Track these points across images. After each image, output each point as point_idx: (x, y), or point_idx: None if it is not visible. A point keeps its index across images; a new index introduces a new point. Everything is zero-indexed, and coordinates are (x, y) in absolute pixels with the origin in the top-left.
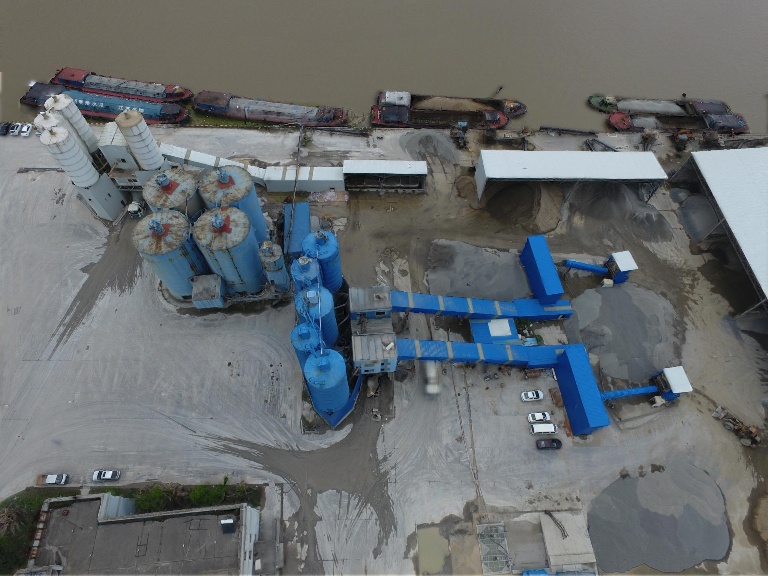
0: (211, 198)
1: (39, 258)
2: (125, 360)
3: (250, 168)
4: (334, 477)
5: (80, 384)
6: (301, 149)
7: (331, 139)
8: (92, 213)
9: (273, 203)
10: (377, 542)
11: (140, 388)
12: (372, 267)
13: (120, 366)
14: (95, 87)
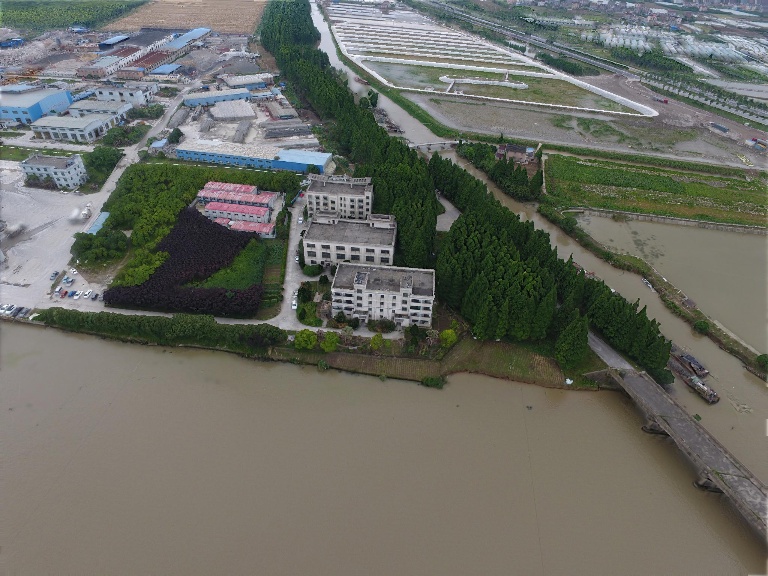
0: None
1: (46, 245)
2: None
3: None
4: (1, 185)
5: None
6: None
7: None
8: (8, 259)
9: None
10: (4, 176)
11: None
12: None
13: None
14: None
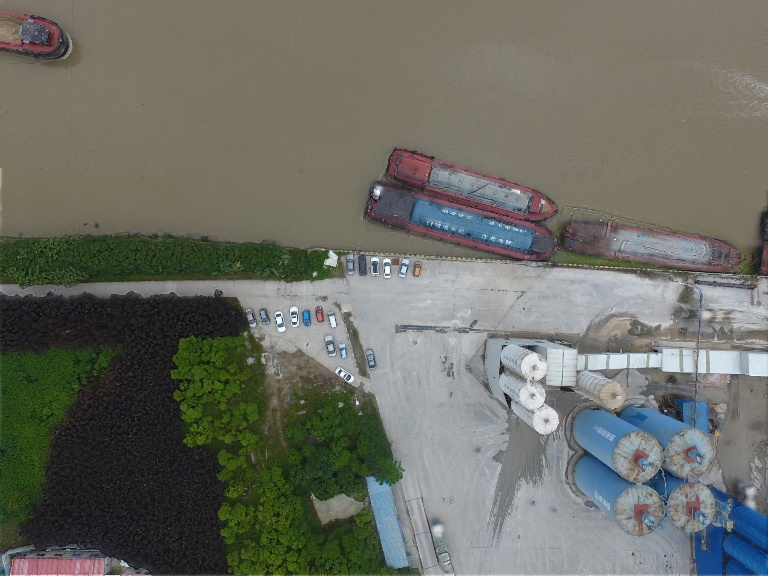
0: (678, 472)
1: (452, 444)
2: (551, 549)
3: (651, 358)
4: None
5: (521, 568)
6: (682, 306)
7: (714, 291)
8: (486, 391)
9: (657, 382)
10: None
11: (568, 572)
12: (748, 463)
13: (548, 554)
14: (441, 191)
